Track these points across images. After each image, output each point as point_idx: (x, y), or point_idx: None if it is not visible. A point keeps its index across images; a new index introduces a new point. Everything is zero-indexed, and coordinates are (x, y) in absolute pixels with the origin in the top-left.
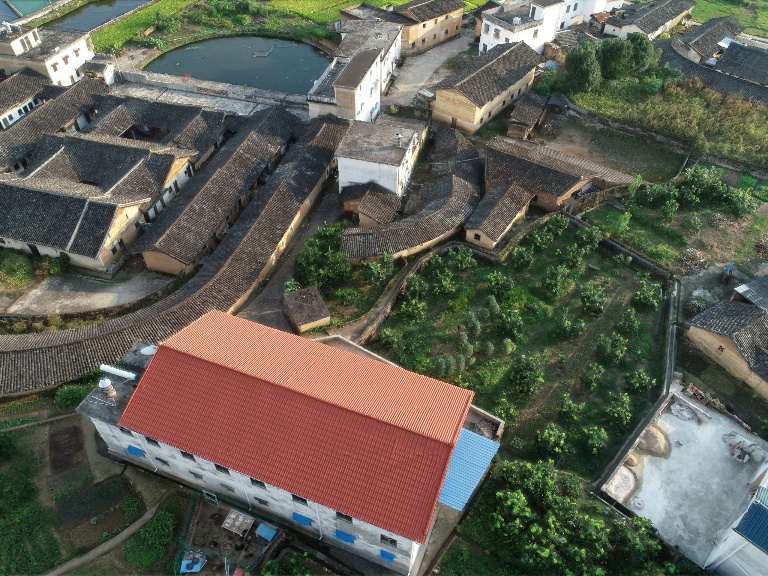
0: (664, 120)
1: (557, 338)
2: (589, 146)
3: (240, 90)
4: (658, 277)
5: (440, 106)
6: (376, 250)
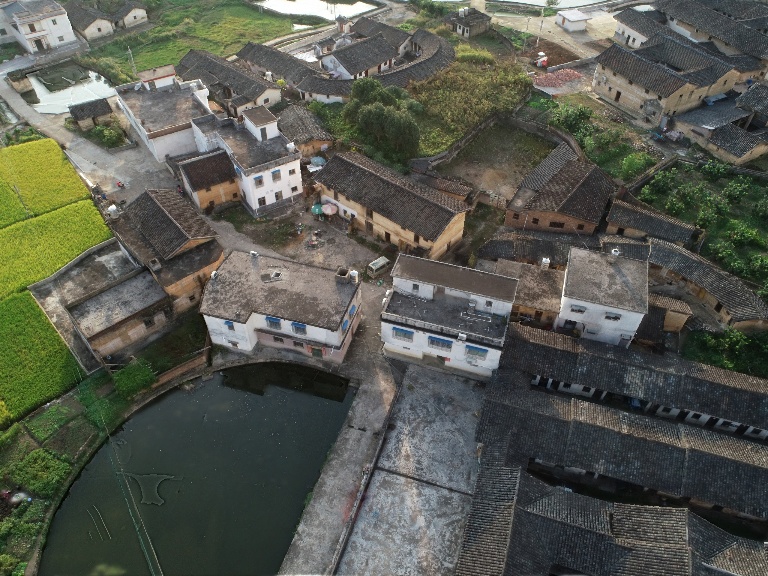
0: (471, 114)
1: (766, 221)
2: (484, 167)
3: (328, 502)
4: (673, 166)
5: (437, 247)
6: (759, 298)
